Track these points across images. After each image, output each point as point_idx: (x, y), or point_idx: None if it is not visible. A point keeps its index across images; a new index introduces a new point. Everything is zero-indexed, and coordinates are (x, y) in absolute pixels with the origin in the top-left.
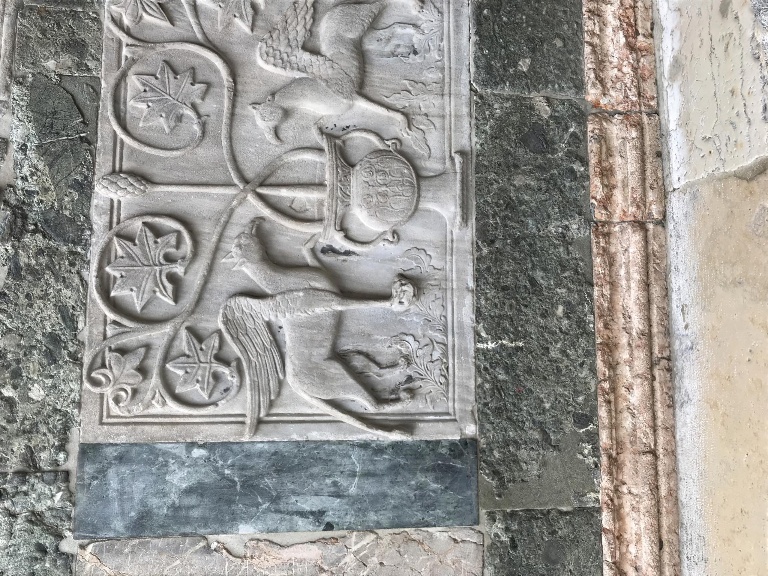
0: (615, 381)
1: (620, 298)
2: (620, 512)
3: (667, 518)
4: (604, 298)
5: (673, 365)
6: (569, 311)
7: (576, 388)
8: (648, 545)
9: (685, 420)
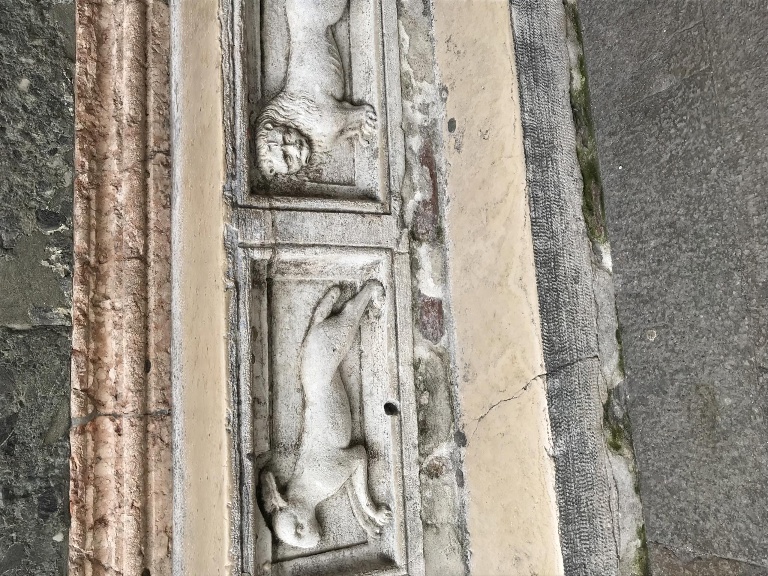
0: (100, 178)
1: (112, 82)
2: (100, 332)
3: (156, 335)
4: (88, 78)
5: (172, 161)
6: (38, 88)
7: (42, 180)
8: (129, 366)
9: (175, 217)
